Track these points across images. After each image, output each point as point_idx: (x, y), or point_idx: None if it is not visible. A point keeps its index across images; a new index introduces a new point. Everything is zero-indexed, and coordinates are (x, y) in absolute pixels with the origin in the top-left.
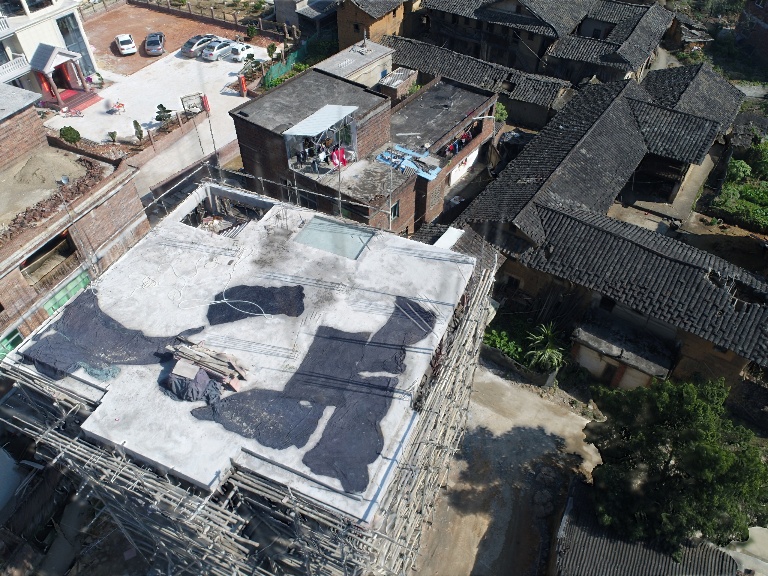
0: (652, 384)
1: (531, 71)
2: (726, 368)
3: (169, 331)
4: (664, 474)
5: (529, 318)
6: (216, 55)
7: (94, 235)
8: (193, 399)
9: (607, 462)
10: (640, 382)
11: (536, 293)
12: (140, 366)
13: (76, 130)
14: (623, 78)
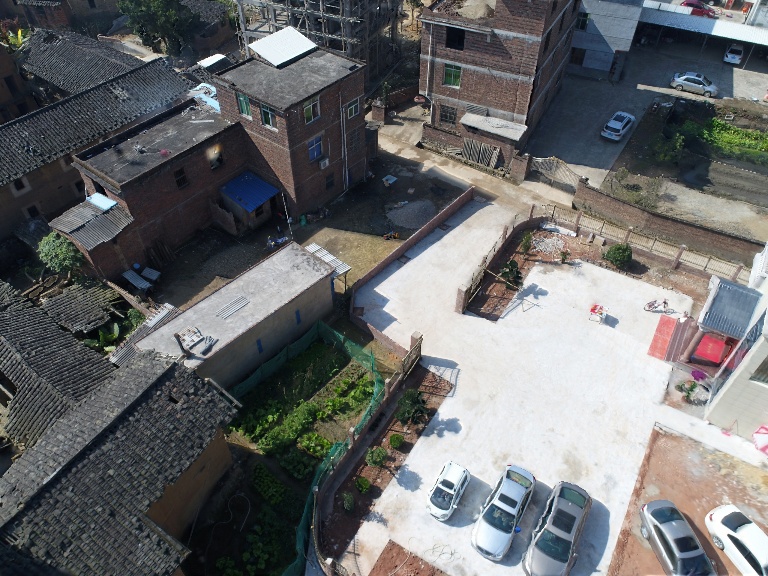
0: None
1: None
2: None
3: None
4: None
5: None
6: None
7: None
8: None
9: None
10: None
11: None
12: None
13: None
14: None
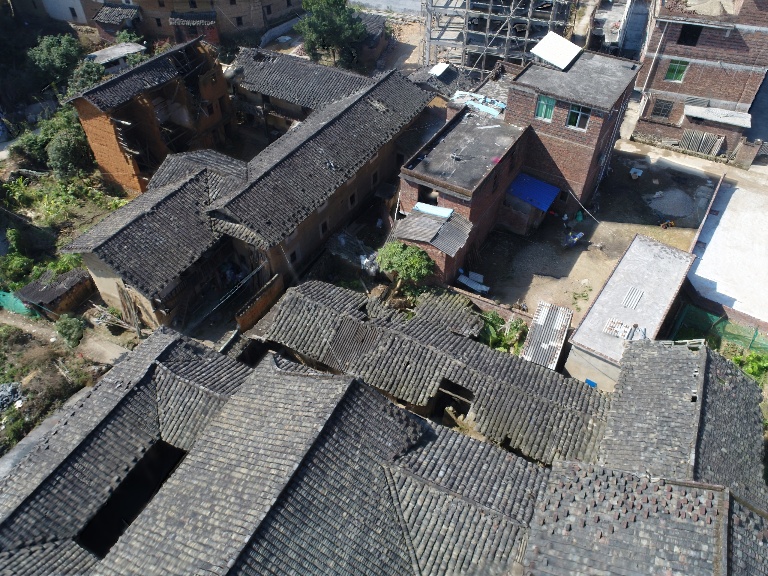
0: None
1: None
2: None
3: None
4: None
5: None
6: None
7: None
8: None
9: None
10: None
11: None
12: None
13: None
14: None
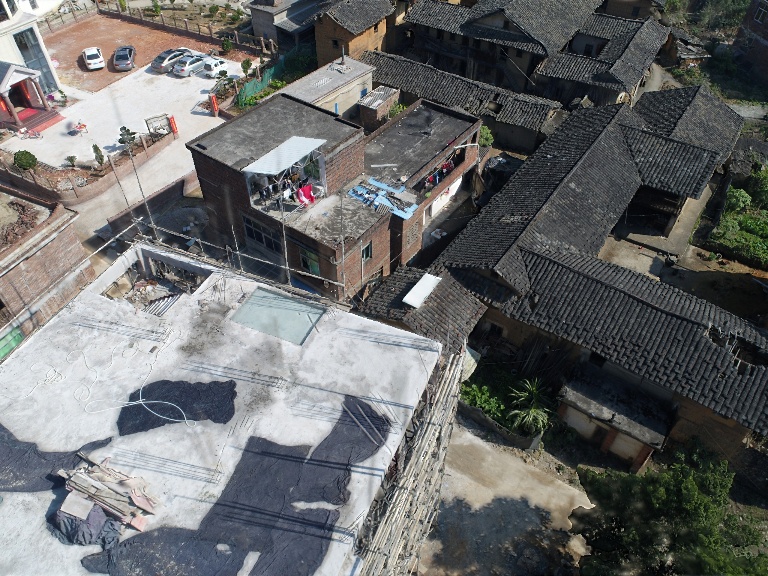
0: (646, 475)
1: (520, 89)
2: (727, 434)
3: (69, 444)
4: (660, 575)
5: (513, 369)
6: (188, 71)
7: (26, 288)
8: (85, 543)
9: (596, 549)
10: (633, 447)
11: (520, 343)
12: (27, 494)
13: (33, 154)
14: (616, 99)
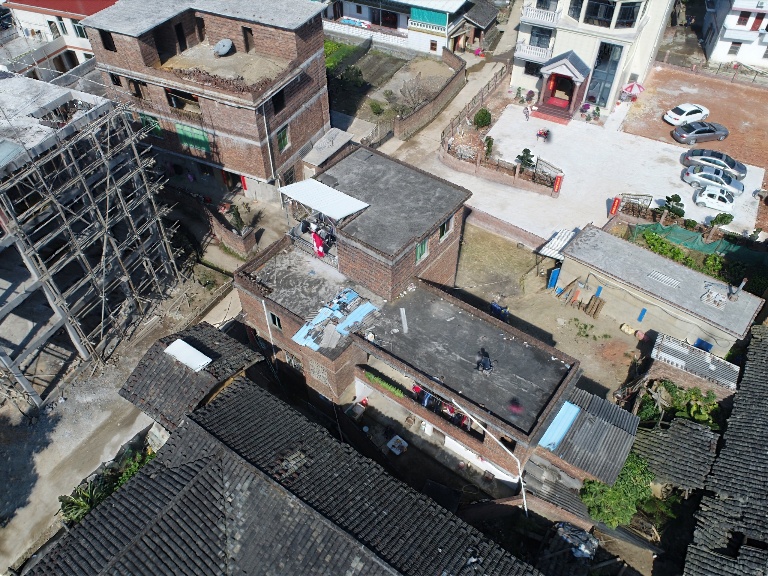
0: None
1: None
2: None
3: None
4: None
5: None
6: (693, 179)
7: (216, 118)
8: None
9: None
10: None
11: None
12: None
13: None
14: None
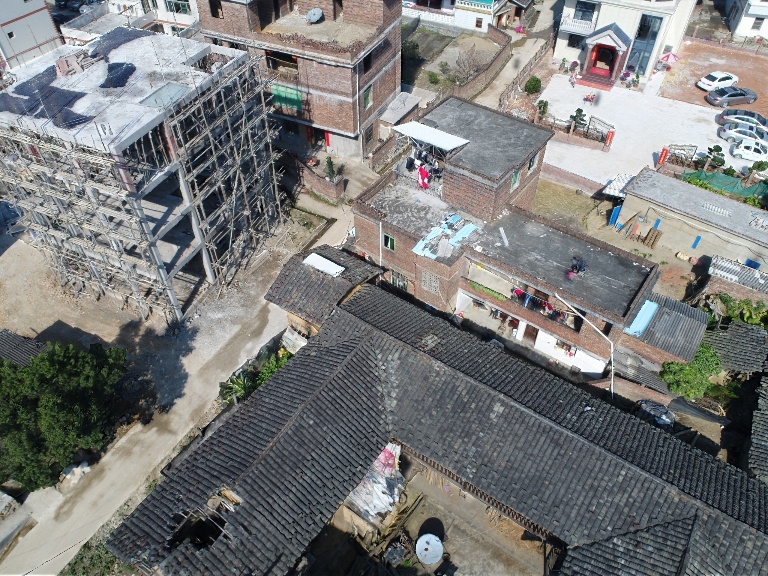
0: None
1: None
2: None
3: None
4: None
5: None
6: (729, 135)
7: (312, 77)
8: None
9: None
10: None
11: None
12: None
13: None
14: None
